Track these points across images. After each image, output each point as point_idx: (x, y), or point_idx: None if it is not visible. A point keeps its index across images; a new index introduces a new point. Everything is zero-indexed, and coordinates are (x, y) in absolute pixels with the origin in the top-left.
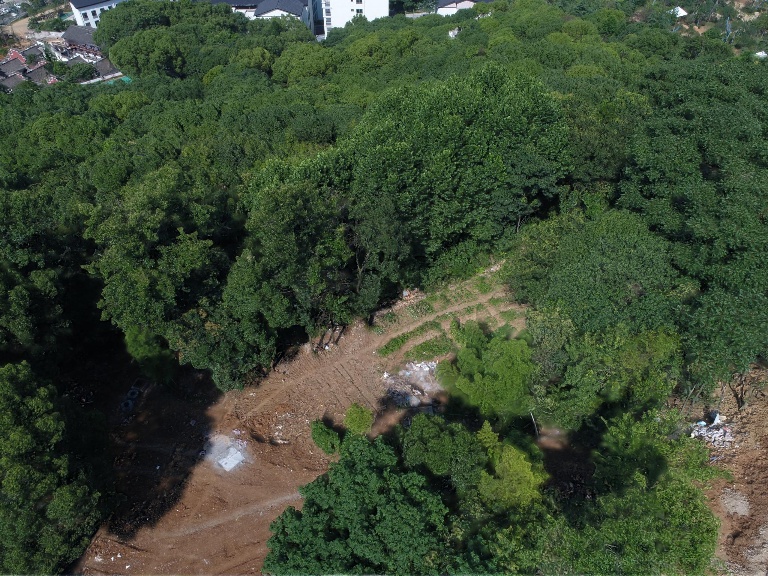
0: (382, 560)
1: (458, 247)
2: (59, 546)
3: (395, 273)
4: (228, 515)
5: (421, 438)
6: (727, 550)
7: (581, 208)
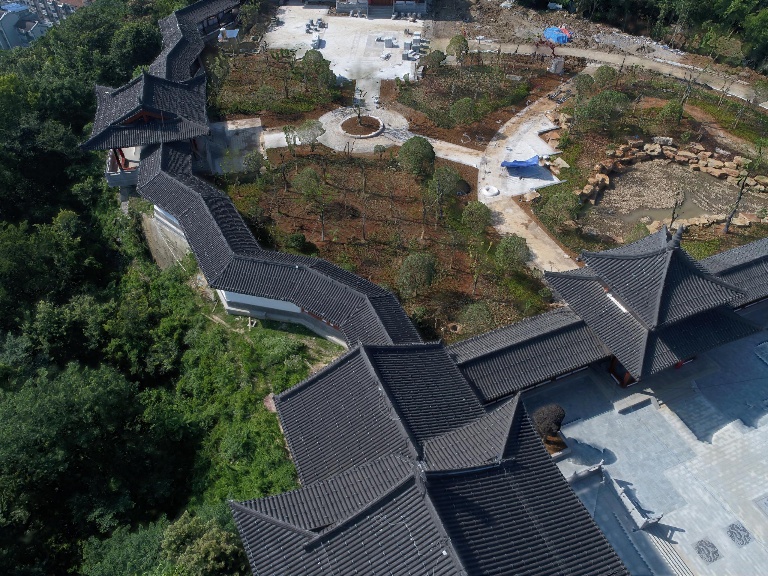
0: None
1: None
2: None
3: None
4: None
5: None
6: None
7: None
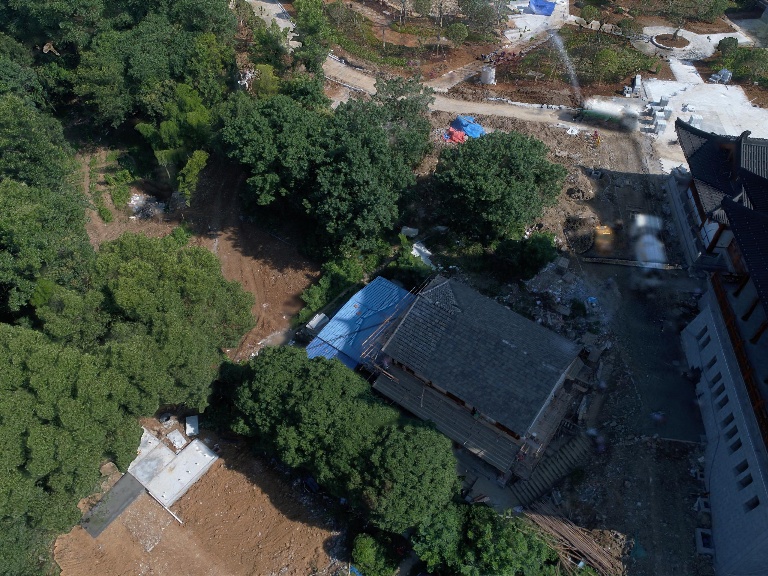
0: (297, 113)
1: None
2: None
3: None
4: None
5: (232, 111)
6: None
7: (44, 91)
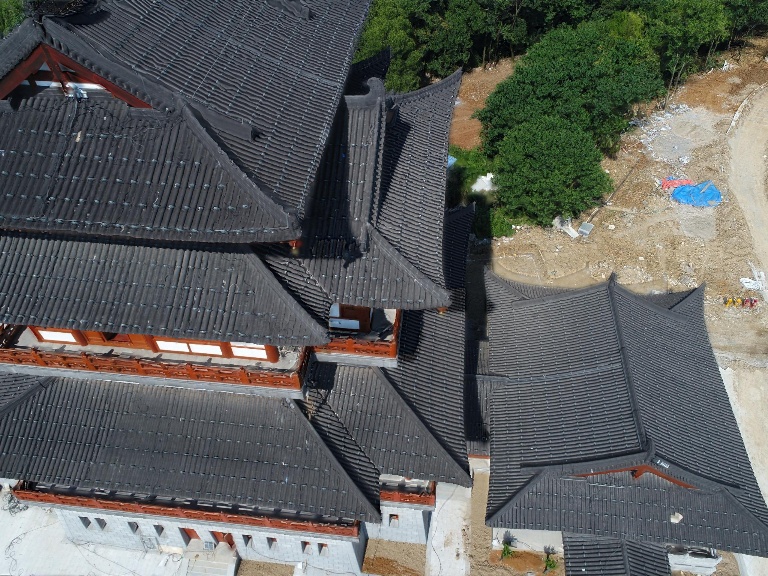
0: (580, 46)
1: (562, 25)
2: (411, 80)
3: (540, 7)
4: (460, 118)
5: None
6: (729, 92)
7: None
